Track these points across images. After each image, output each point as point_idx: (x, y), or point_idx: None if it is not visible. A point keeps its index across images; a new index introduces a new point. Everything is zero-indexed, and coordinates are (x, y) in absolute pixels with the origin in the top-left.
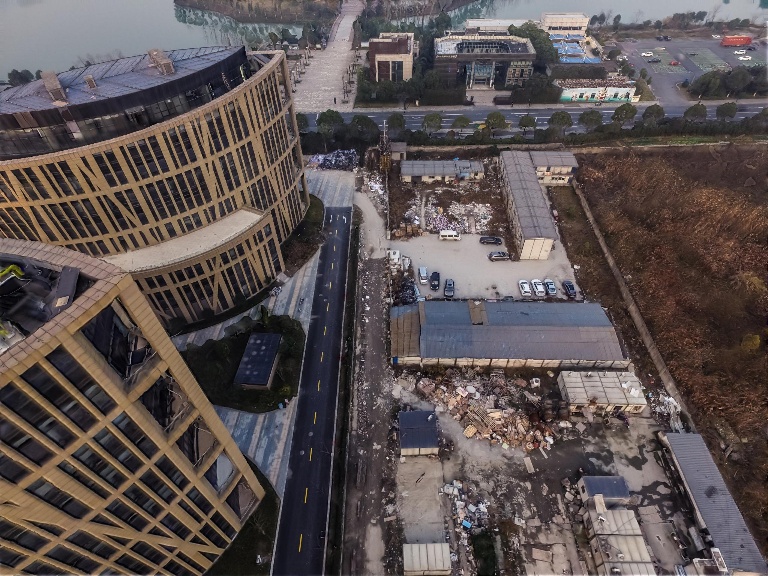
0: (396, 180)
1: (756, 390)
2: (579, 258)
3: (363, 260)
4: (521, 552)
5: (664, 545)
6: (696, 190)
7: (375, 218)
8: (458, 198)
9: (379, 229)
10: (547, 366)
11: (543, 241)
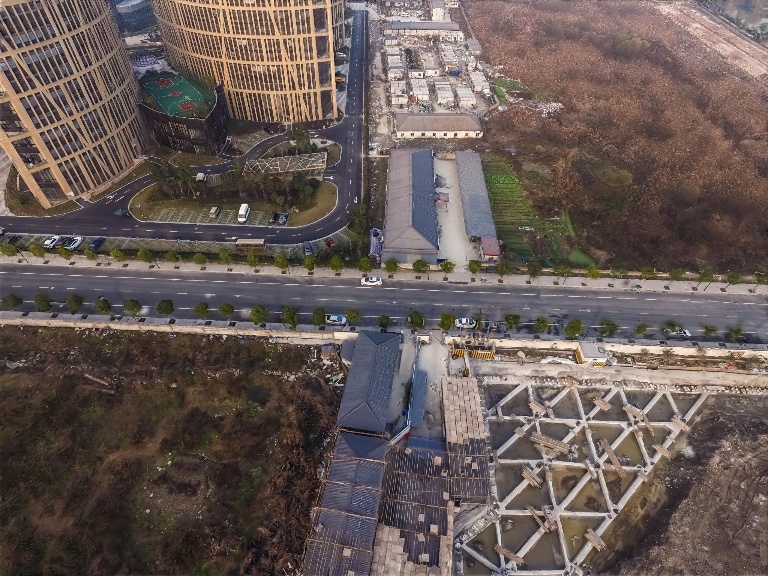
0: (383, 6)
1: (499, 35)
2: (455, 19)
3: (370, 20)
4: (419, 54)
5: (459, 54)
6: (506, 3)
7: (374, 13)
8: (410, 9)
9: (376, 15)
10: (435, 35)
11: (440, 10)
